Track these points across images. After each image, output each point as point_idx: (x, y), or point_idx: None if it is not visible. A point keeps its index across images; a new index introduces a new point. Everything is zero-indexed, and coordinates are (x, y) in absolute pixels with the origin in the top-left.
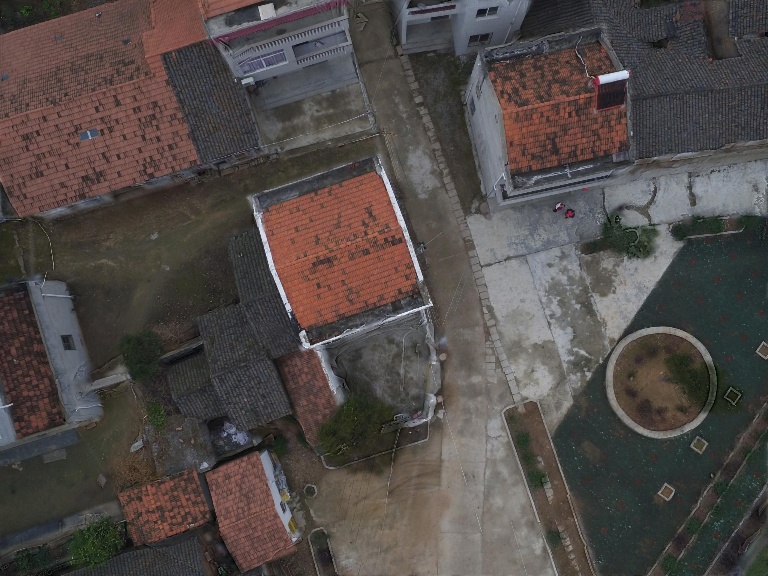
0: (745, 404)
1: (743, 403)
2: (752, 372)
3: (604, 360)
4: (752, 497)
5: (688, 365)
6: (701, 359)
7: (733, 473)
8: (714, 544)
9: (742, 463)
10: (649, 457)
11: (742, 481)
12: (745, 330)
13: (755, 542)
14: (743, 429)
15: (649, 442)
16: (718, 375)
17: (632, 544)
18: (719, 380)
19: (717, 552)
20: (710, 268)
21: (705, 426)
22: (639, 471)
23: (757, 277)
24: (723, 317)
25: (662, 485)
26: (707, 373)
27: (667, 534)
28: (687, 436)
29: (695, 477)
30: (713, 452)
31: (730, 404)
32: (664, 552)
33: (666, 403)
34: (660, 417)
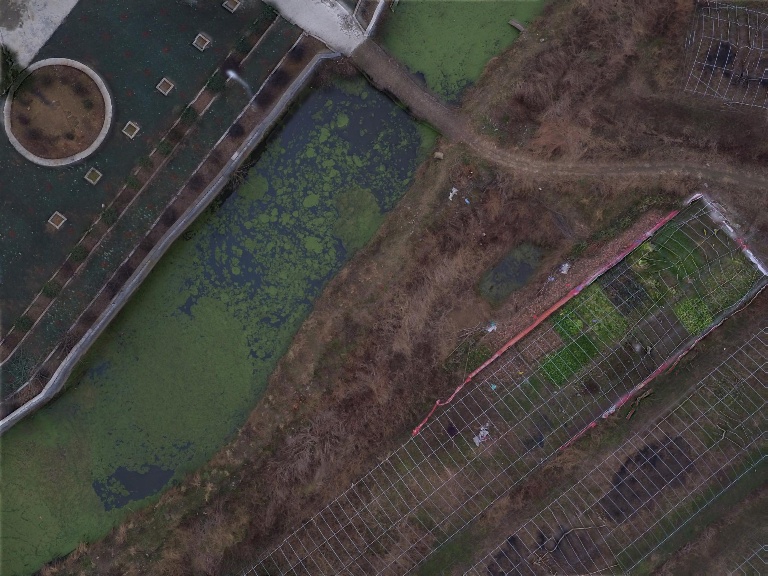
0: (143, 138)
1: (141, 137)
2: (152, 108)
3: (6, 91)
4: (144, 229)
5: (83, 96)
6: (98, 91)
7: (125, 204)
8: (103, 274)
9: (135, 195)
10: (44, 186)
11: (133, 212)
12: (148, 67)
13: (162, 282)
14: (138, 162)
15: (45, 172)
16: (115, 108)
17: (21, 271)
18: (117, 113)
19: (105, 281)
20: (117, 6)
21: (101, 158)
22: (33, 200)
23: (162, 16)
24: (126, 53)
25: (52, 213)
26: (103, 105)
27: (56, 262)
28: (83, 167)
29: (89, 208)
30: (107, 183)
31: (128, 138)
32: (52, 279)
33: (59, 132)
34: (50, 145)
